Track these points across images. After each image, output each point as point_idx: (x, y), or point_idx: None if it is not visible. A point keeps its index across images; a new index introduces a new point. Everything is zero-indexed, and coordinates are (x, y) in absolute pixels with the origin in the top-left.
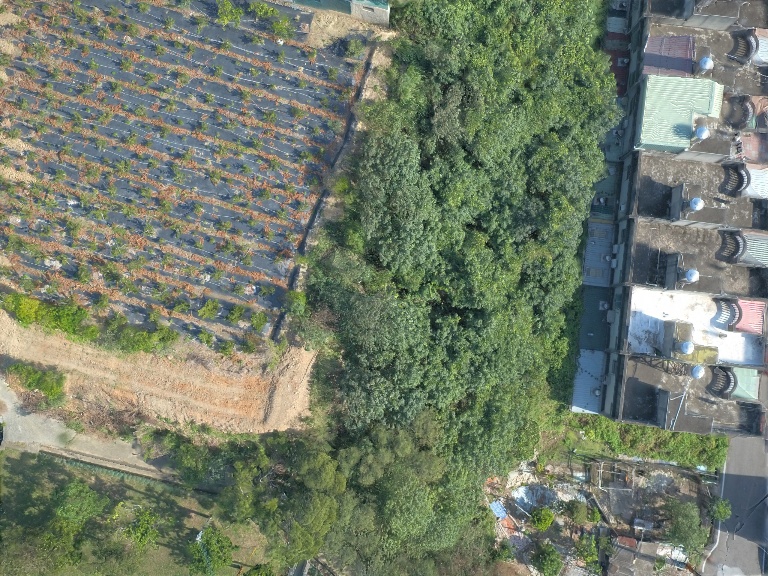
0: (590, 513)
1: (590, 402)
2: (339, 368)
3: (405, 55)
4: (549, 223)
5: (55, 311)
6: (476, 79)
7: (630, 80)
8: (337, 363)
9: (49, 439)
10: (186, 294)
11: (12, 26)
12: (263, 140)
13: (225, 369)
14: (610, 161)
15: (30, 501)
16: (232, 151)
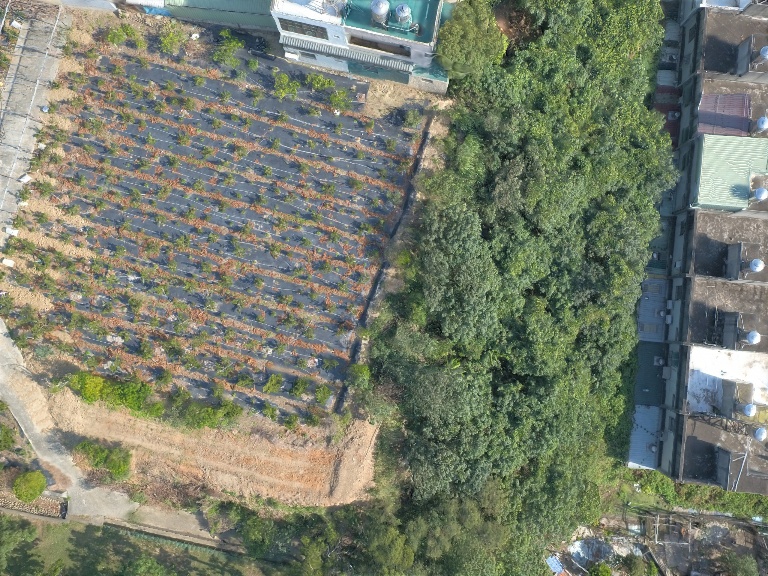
0: (646, 567)
1: (646, 458)
2: (402, 438)
3: (463, 124)
4: (610, 289)
5: (120, 389)
6: (536, 149)
7: (683, 136)
8: (400, 433)
9: (113, 512)
10: (249, 368)
11: (68, 101)
12: (322, 212)
13: (290, 443)
14: (662, 215)
15: (96, 574)
16: (291, 223)
